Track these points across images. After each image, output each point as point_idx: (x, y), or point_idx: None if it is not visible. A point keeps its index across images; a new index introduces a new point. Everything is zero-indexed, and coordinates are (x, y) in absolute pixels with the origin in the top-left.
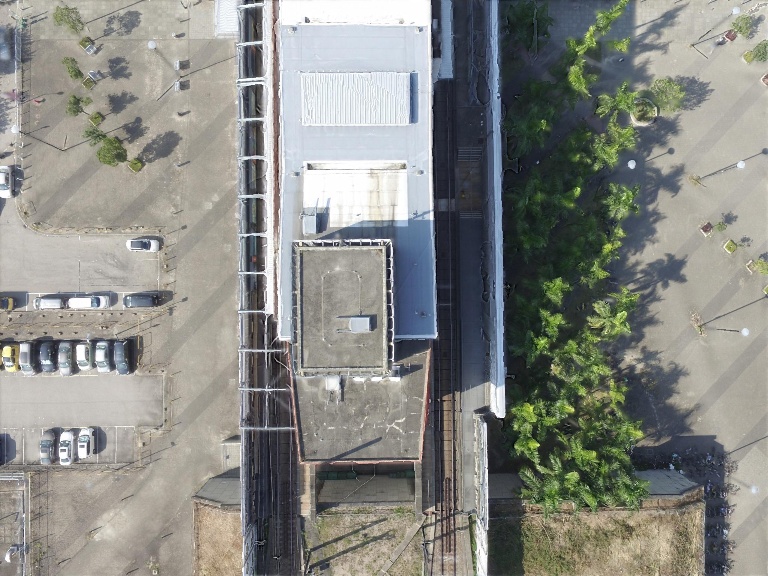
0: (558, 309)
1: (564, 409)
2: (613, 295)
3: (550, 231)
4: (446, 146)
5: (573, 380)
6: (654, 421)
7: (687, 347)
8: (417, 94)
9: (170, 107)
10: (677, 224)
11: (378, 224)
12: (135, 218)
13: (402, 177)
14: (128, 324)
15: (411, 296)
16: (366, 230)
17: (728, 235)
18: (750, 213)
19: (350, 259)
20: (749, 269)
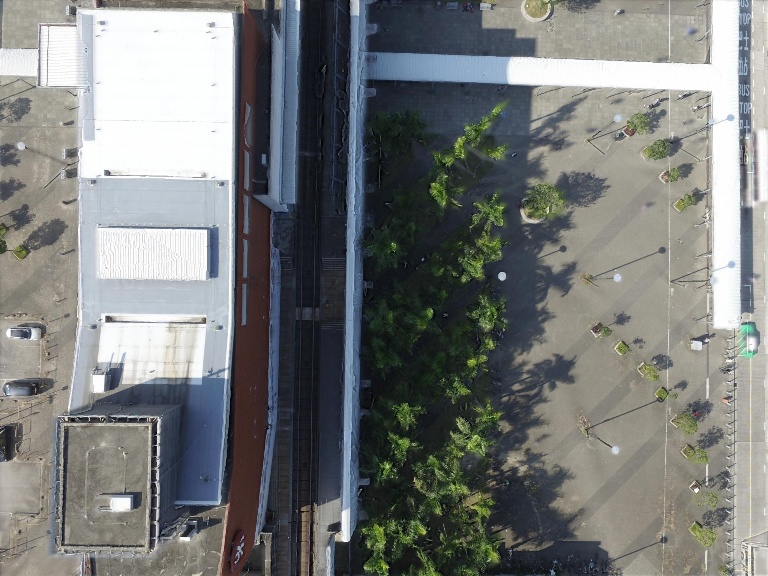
0: (413, 429)
1: (418, 529)
2: (477, 410)
3: (415, 343)
4: (312, 254)
5: (433, 496)
6: (536, 525)
7: (573, 450)
8: (217, 249)
9: (57, 195)
10: (566, 324)
11: (171, 381)
12: (19, 305)
13: (201, 332)
14: (8, 411)
15: (197, 460)
16: (158, 388)
17: (620, 336)
18: (643, 314)
19: (116, 435)
20: (640, 372)
